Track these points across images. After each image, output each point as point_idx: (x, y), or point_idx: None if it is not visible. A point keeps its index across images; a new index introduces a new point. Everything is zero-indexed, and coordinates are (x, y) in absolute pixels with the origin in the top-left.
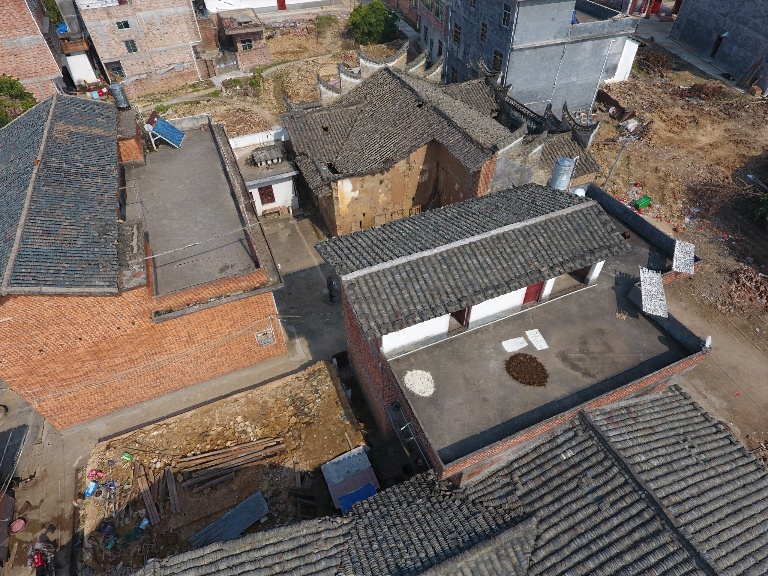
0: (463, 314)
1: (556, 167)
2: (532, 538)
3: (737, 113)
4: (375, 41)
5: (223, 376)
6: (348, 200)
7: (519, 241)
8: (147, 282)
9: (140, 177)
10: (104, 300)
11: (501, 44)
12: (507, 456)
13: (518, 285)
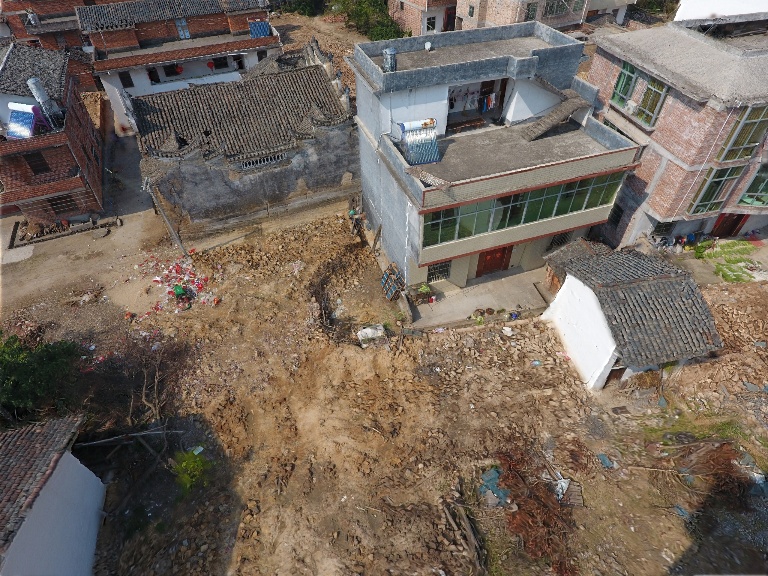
0: None
1: None
2: None
3: (405, 527)
4: None
5: None
6: None
7: None
8: (98, 41)
9: (220, 37)
10: None
11: None
12: None
13: None
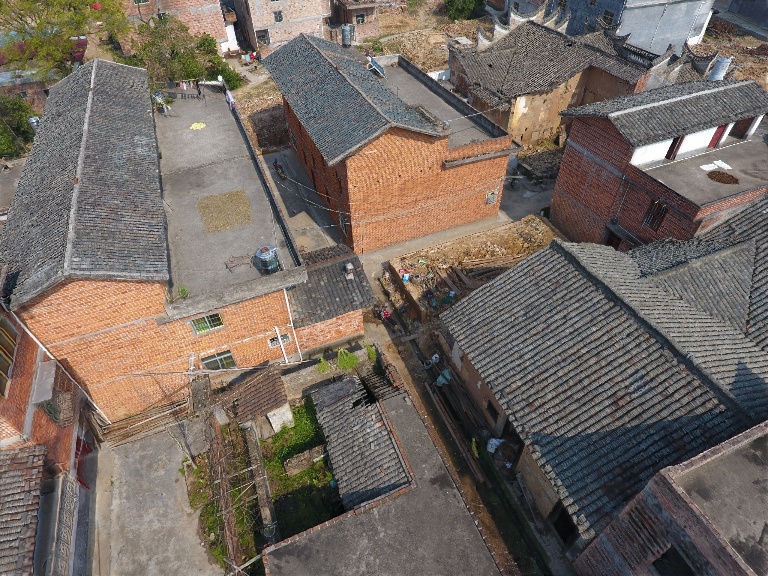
0: (673, 149)
1: (716, 65)
2: (754, 249)
3: None
4: (465, 18)
5: (456, 228)
6: (519, 115)
7: (711, 100)
8: None
9: None
10: (424, 145)
11: (613, 5)
12: (724, 217)
13: (717, 123)
